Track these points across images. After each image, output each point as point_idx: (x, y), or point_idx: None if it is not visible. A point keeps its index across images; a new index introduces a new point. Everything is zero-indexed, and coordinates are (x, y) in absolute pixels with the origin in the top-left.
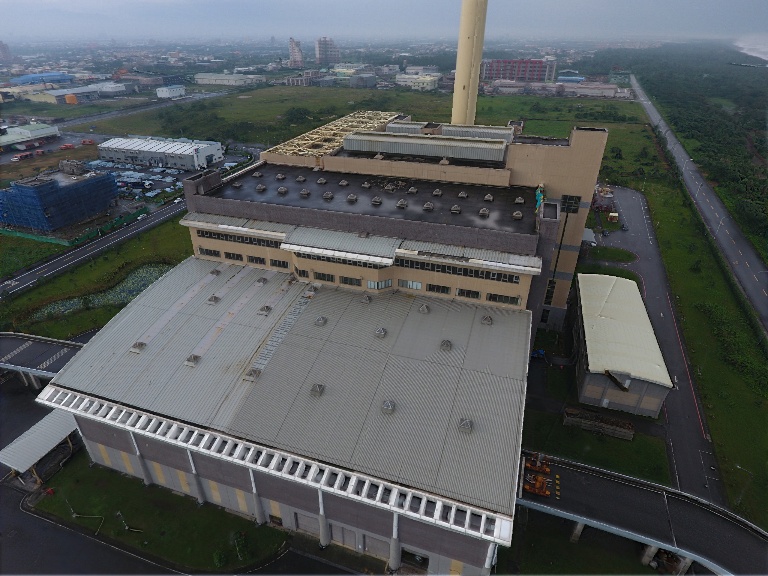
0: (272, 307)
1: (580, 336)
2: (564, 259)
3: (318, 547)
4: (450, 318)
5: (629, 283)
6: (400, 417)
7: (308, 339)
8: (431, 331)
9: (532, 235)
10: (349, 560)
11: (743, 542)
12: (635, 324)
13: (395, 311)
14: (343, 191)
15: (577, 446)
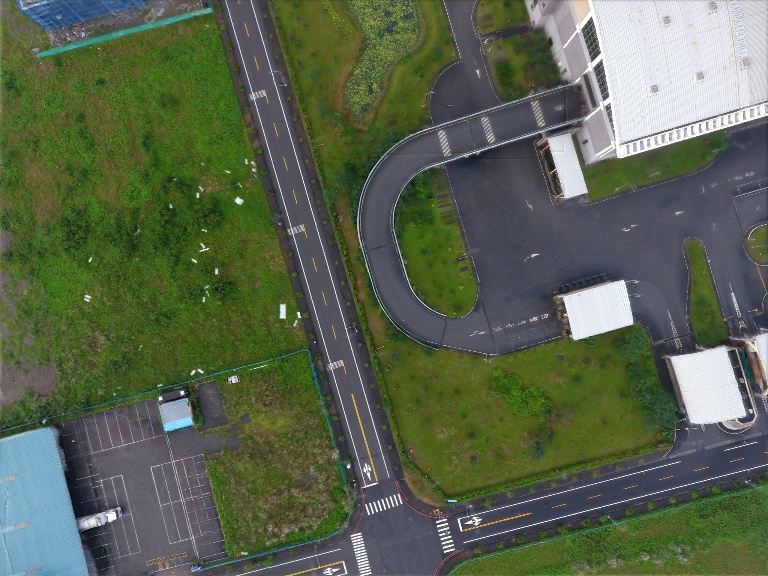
0: (714, 1)
1: None
2: None
3: (743, 123)
4: None
5: None
6: None
7: (760, 15)
8: None
9: None
10: (761, 119)
11: None
12: None
13: None
14: None
15: None
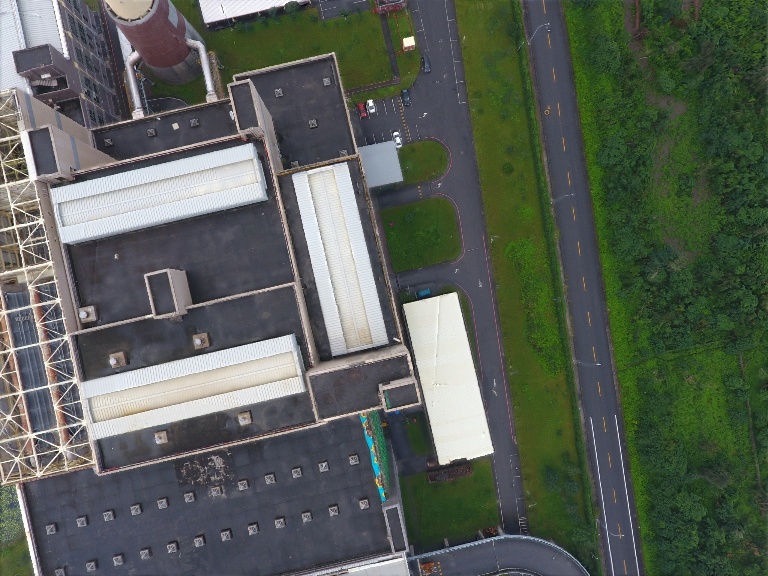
0: None
1: (425, 412)
2: None
3: None
4: None
5: (451, 302)
6: None
7: None
8: None
9: None
10: None
11: (528, 549)
12: (463, 382)
13: None
14: (175, 522)
15: (441, 497)
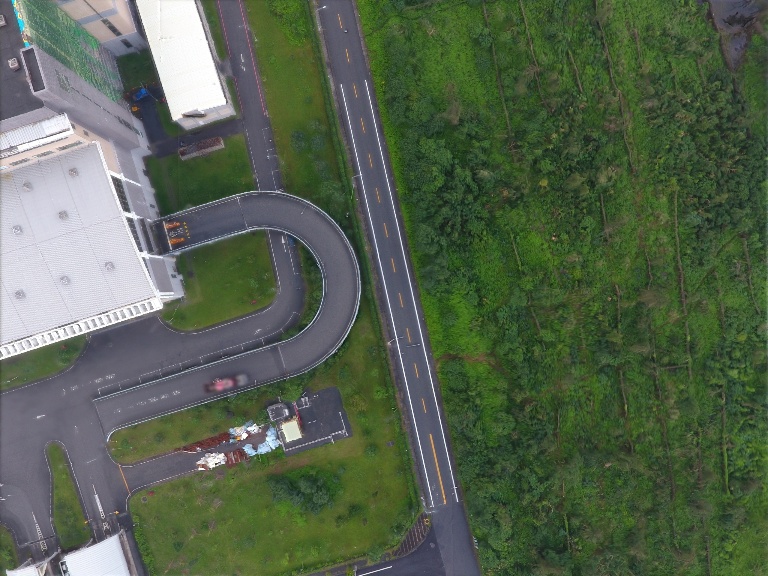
0: None
1: None
2: (94, 2)
3: None
4: (49, 185)
5: None
6: (75, 282)
7: None
8: (46, 207)
9: (40, 109)
10: None
11: (275, 204)
12: (189, 35)
13: (10, 201)
14: None
15: (196, 174)
